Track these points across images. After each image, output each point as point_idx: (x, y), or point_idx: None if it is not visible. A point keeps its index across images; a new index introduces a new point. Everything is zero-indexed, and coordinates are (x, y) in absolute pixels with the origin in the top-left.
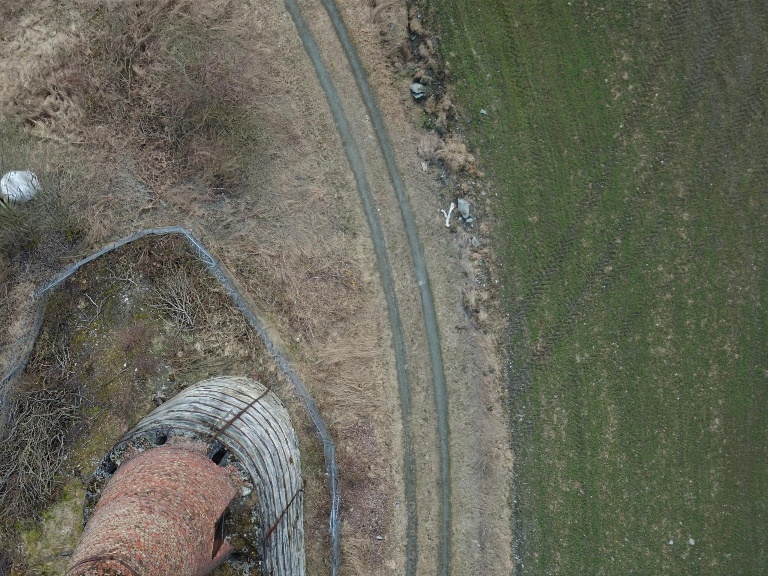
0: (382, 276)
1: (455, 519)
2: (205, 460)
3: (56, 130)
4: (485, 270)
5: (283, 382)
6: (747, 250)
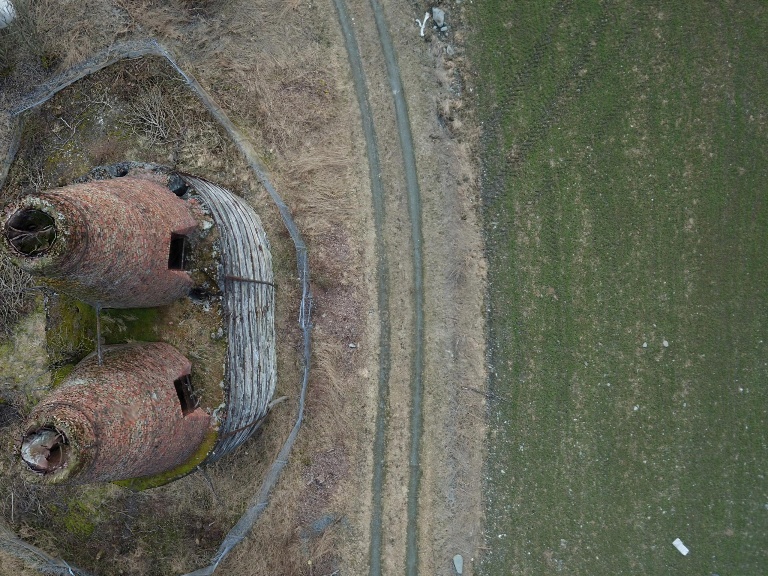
0: (356, 85)
1: (428, 328)
2: (165, 189)
3: None
4: (460, 79)
5: (256, 191)
6: (722, 47)
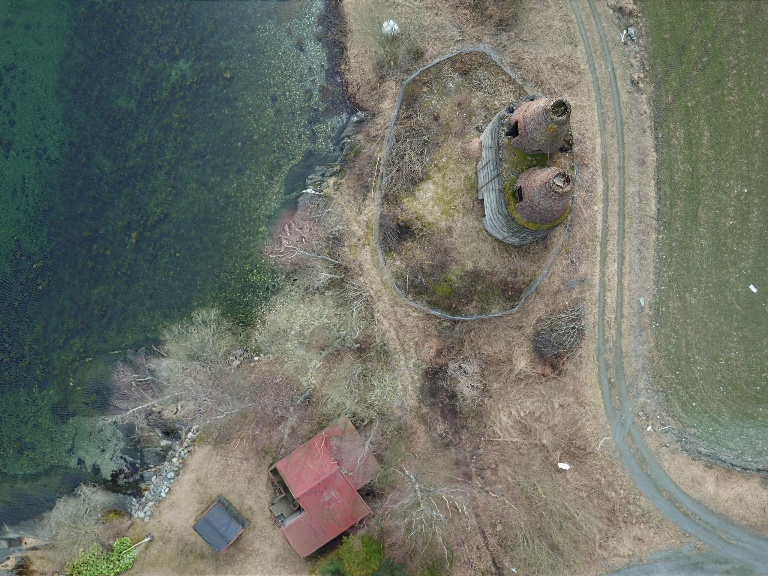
0: (590, 66)
1: (627, 186)
2: None
3: (408, 0)
4: (642, 63)
5: None
6: None
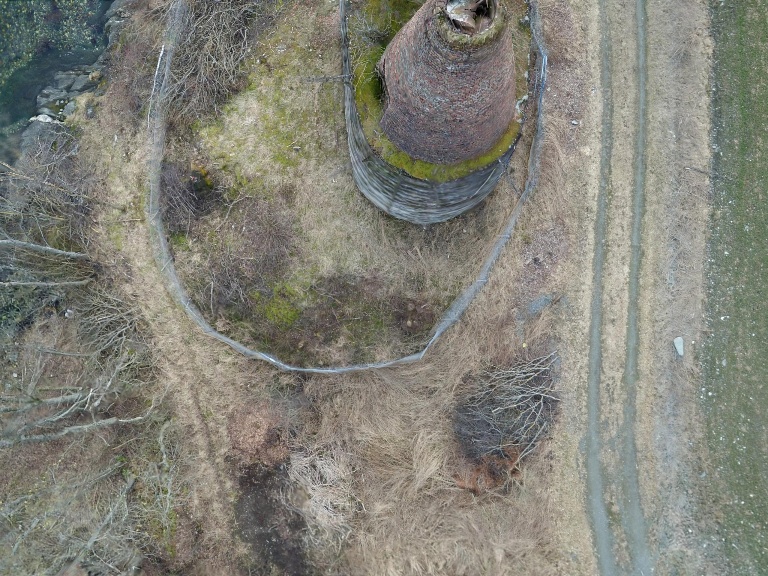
0: None
1: (651, 107)
2: None
3: None
4: None
5: None
6: None
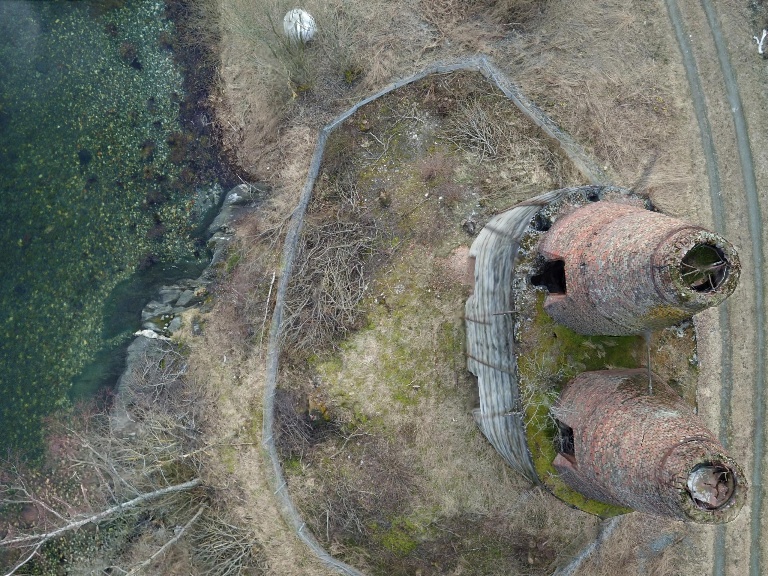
0: (695, 102)
1: None
2: None
3: None
4: None
5: None
6: None
